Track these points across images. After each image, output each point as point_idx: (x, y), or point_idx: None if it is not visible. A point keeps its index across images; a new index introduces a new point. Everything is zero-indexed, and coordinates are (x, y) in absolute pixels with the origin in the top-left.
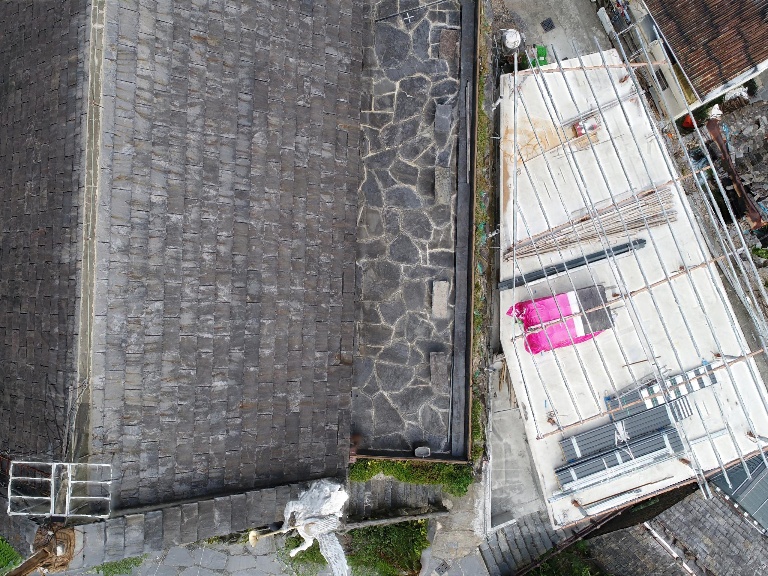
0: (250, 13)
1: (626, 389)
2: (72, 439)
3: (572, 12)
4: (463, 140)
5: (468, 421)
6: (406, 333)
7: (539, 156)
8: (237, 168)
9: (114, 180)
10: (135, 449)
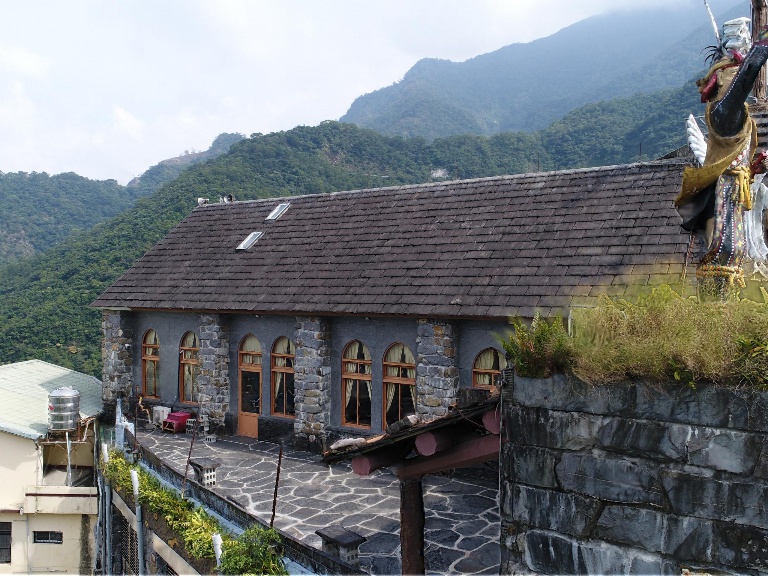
0: None
1: None
2: None
3: None
4: None
5: None
6: None
7: None
8: None
9: None
10: None
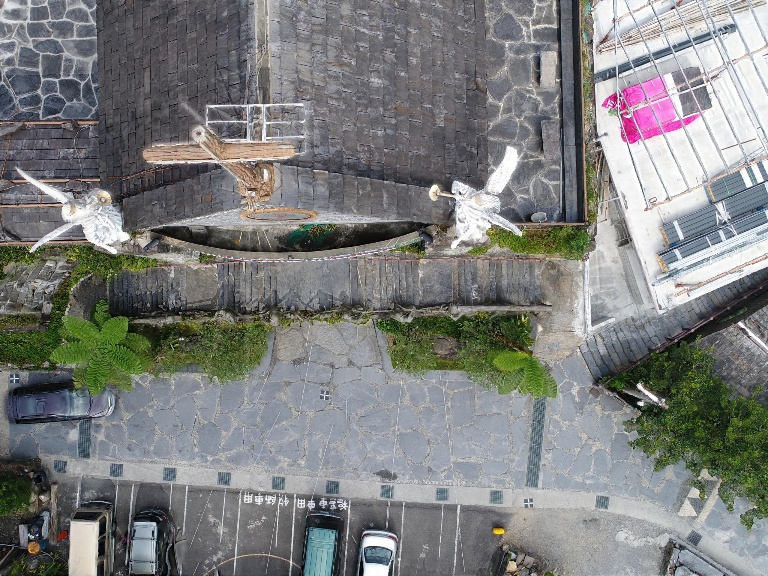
0: None
1: (724, 172)
2: (257, 96)
3: None
4: None
5: (583, 184)
6: (514, 109)
7: None
8: None
9: None
10: (309, 123)
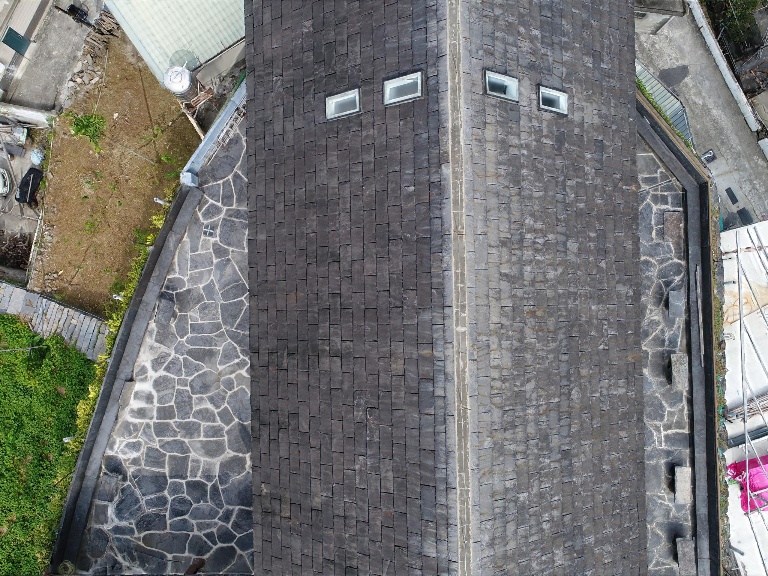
0: (563, 273)
1: None
2: None
3: (733, 142)
4: (695, 324)
5: None
6: None
7: (746, 317)
8: (561, 429)
9: (480, 477)
10: None
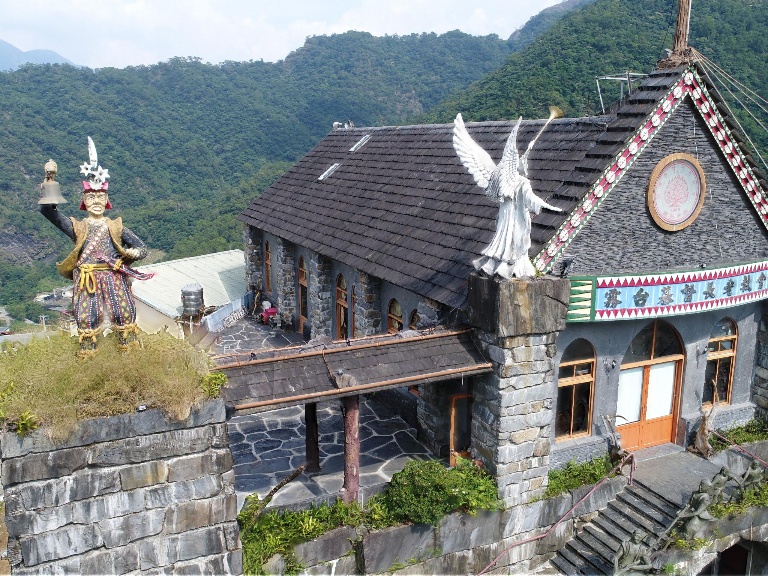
0: None
1: None
2: None
3: None
4: None
5: None
6: None
7: None
8: None
9: None
10: None
